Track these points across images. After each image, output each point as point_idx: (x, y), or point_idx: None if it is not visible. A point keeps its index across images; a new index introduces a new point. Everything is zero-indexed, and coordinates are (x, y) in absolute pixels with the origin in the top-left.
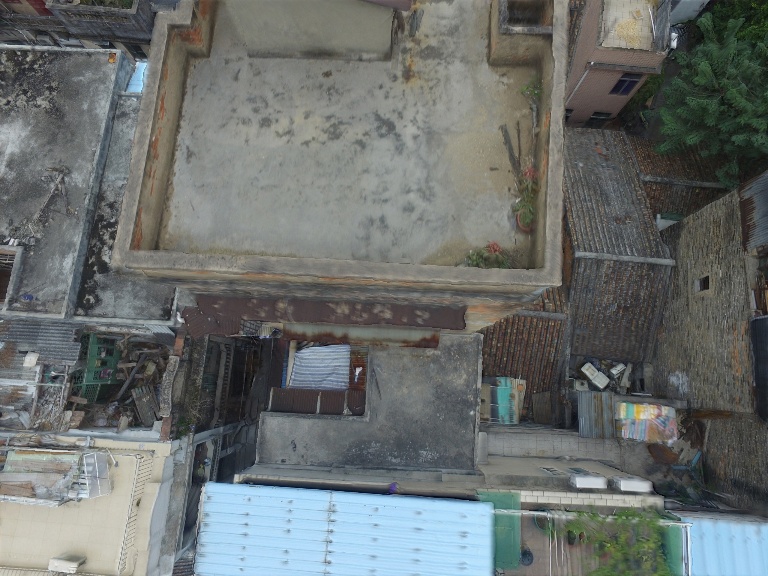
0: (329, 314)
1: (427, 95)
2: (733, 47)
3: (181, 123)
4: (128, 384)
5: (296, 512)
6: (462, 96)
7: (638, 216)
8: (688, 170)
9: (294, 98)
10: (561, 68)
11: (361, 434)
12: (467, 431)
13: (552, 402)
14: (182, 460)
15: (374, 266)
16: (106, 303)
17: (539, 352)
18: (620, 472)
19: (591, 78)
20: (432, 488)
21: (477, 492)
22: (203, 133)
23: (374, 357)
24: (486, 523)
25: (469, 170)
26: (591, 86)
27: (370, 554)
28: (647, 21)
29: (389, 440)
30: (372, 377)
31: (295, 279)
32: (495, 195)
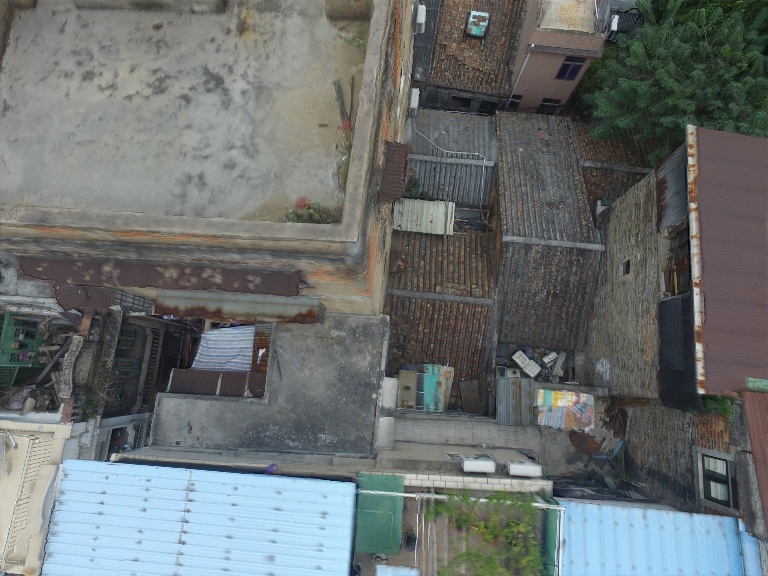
0: (157, 279)
1: (260, 48)
2: (666, 27)
3: (0, 75)
4: (51, 368)
5: (154, 491)
6: (297, 49)
7: (572, 201)
8: (630, 156)
9: (121, 50)
10: (380, 15)
11: (259, 417)
12: (368, 415)
13: (480, 390)
14: (88, 443)
15: (161, 219)
16: (8, 281)
17: (466, 339)
18: (526, 459)
19: (534, 62)
20: (312, 470)
21: (357, 475)
22: (23, 86)
23: (277, 338)
24: (346, 504)
25: (297, 126)
26: (536, 70)
27: (226, 535)
28: (590, 3)
29: (287, 423)
30: (274, 358)
31: (98, 236)
32: (321, 152)
